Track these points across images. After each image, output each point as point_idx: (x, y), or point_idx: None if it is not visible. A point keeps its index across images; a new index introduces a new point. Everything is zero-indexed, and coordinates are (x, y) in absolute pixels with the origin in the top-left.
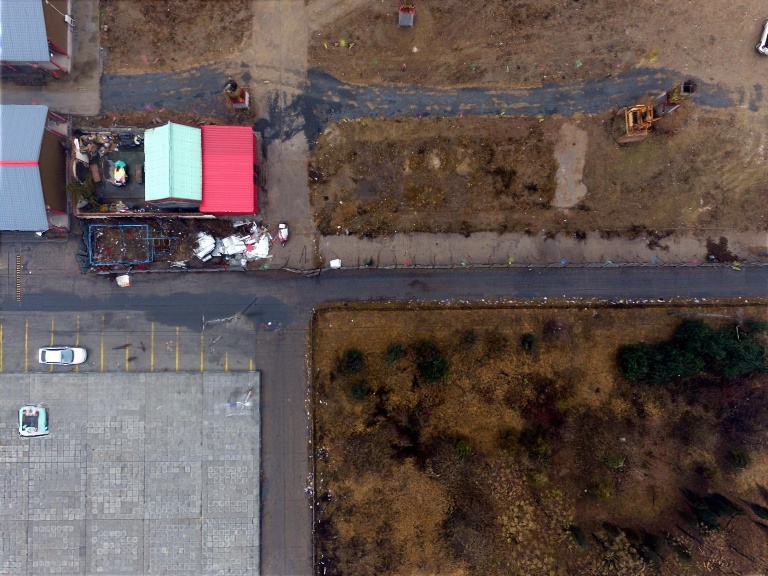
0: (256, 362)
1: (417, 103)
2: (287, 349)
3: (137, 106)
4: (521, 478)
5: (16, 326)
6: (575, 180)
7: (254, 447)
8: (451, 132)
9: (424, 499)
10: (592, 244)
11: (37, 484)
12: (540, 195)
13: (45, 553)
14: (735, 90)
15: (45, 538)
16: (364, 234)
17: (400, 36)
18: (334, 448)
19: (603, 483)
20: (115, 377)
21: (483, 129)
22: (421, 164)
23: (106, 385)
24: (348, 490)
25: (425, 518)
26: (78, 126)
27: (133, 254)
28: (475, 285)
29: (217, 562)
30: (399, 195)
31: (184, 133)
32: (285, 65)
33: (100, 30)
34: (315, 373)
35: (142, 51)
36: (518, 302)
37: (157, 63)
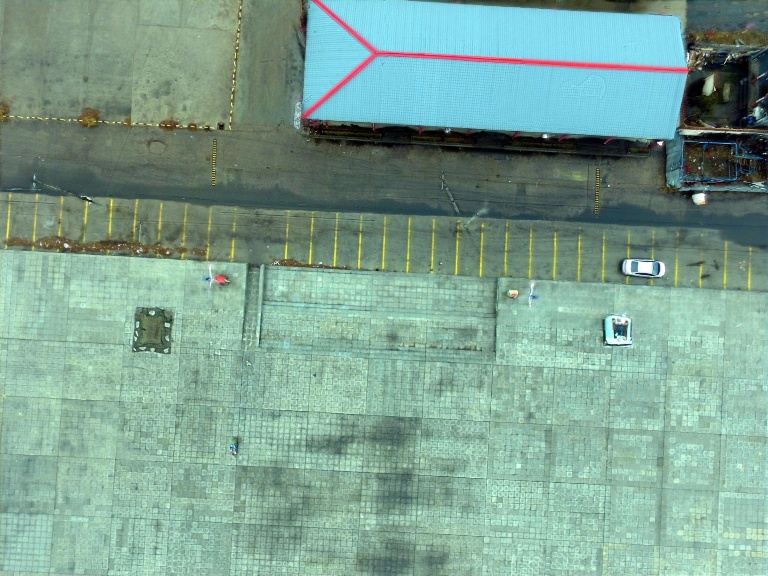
0: None
1: None
2: None
3: (721, 27)
4: None
5: (594, 238)
6: None
7: None
8: None
9: None
10: None
11: (618, 393)
12: None
13: (624, 461)
14: None
15: (624, 446)
16: None
17: None
18: None
19: None
20: (697, 292)
21: None
22: None
23: (688, 300)
24: None
25: None
26: None
27: (709, 173)
28: None
29: None
30: None
31: None
32: None
33: None
34: None
35: None
36: None
37: None
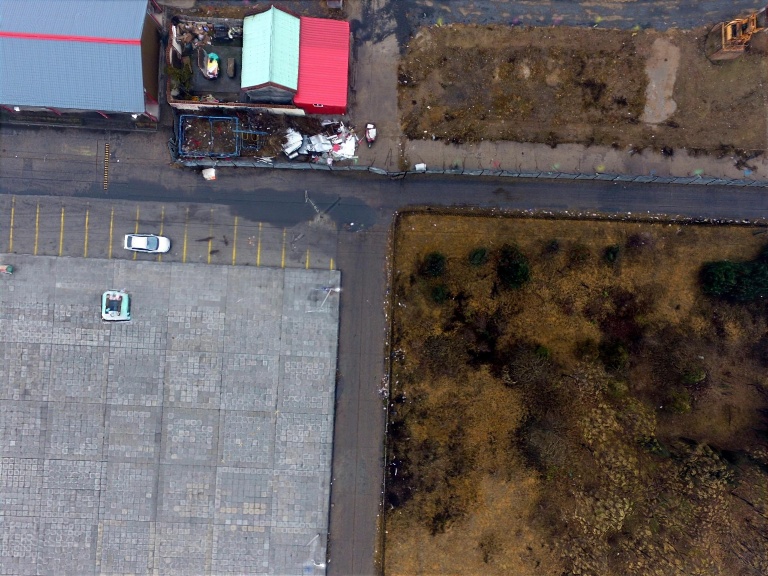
0: (337, 262)
1: (510, 11)
2: (368, 250)
3: (231, 1)
4: (607, 378)
5: (102, 213)
6: (665, 96)
7: (332, 345)
8: (542, 42)
9: (498, 406)
10: (679, 161)
11: (116, 369)
12: (629, 109)
13: (121, 437)
14: None
15: (122, 422)
16: (450, 140)
17: None
18: (411, 351)
19: (682, 397)
20: (198, 267)
21: (575, 40)
22: (511, 73)
23: (189, 275)
24: (423, 393)
25: (499, 425)
26: None
27: (220, 148)
28: (559, 196)
29: (290, 456)
30: (487, 103)
31: (285, 20)
32: None
33: None
34: (395, 275)
35: None
36: (602, 215)
37: None
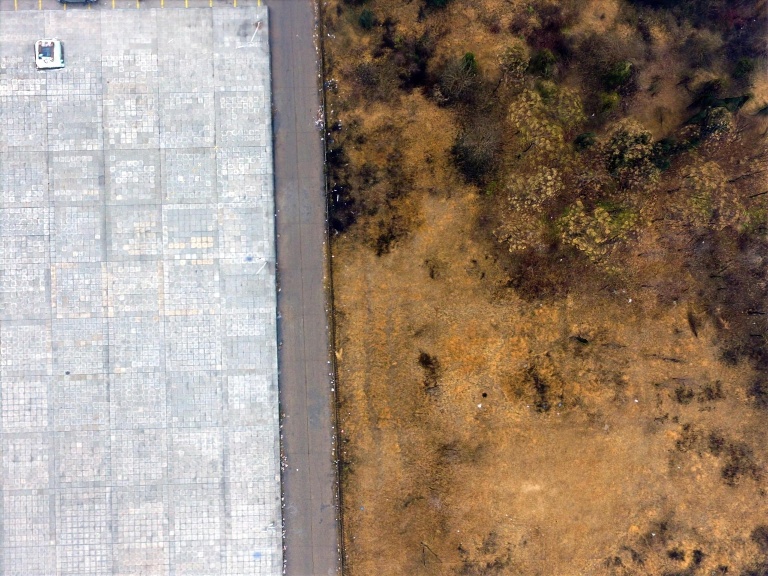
0: None
1: None
2: None
3: None
4: None
5: None
6: None
7: (265, 78)
8: None
9: (433, 126)
10: None
11: (55, 116)
12: None
13: (66, 182)
14: None
15: (65, 168)
16: None
17: None
18: (343, 79)
19: None
20: (127, 12)
21: None
22: None
23: (118, 19)
24: (358, 118)
25: (435, 143)
26: None
27: None
28: None
29: (232, 189)
30: None
31: None
32: None
33: None
34: (322, 6)
35: None
36: None
37: None
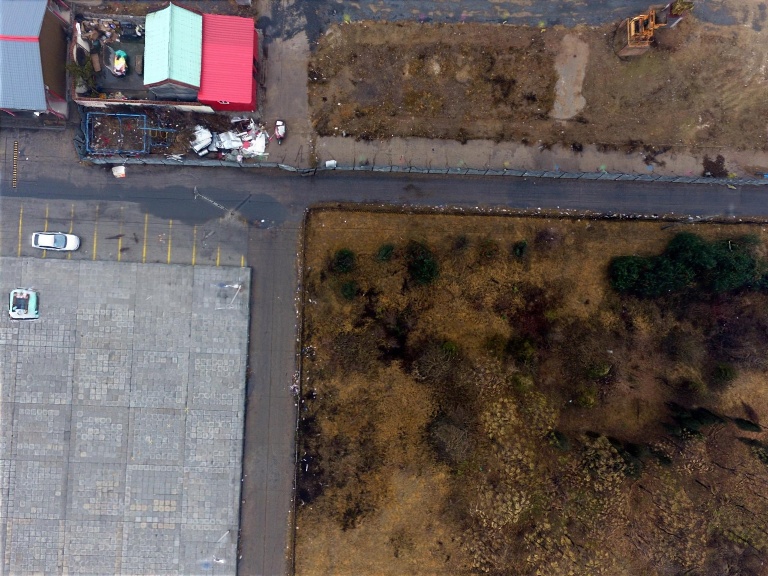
0: (248, 259)
1: (420, 8)
2: (279, 247)
3: None
4: (506, 373)
5: (11, 211)
6: (574, 92)
7: (242, 341)
8: (452, 39)
9: (409, 401)
10: (588, 157)
11: (25, 367)
12: (538, 105)
13: (30, 435)
14: (739, 9)
15: (30, 421)
16: (361, 136)
17: None
18: (321, 347)
19: (588, 391)
20: (107, 265)
21: (484, 37)
22: (421, 69)
23: (97, 273)
24: (333, 389)
25: (409, 420)
26: None
27: (130, 145)
28: (469, 192)
29: (200, 453)
30: (397, 99)
31: (185, 17)
32: None
33: None
34: (306, 271)
35: None
36: (512, 211)
37: None
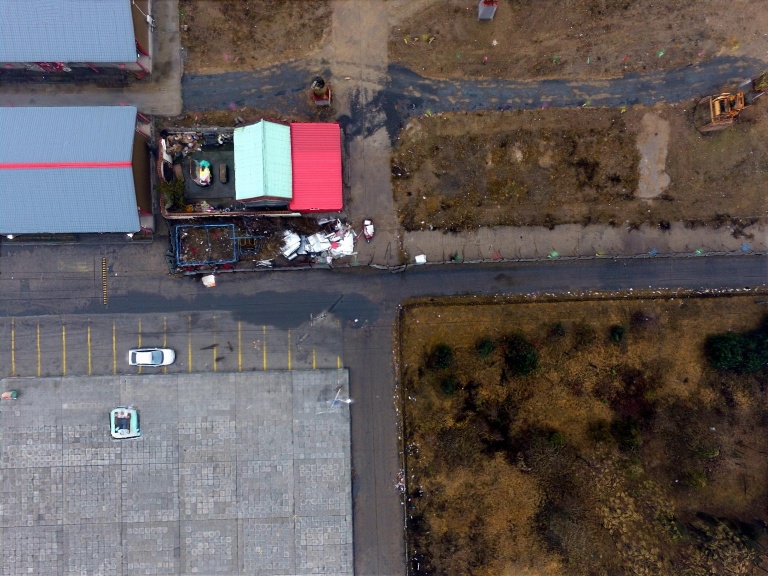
0: (343, 359)
1: (498, 96)
2: (374, 346)
3: (219, 105)
4: (623, 469)
5: (103, 328)
6: (658, 170)
7: (345, 444)
8: (533, 125)
9: (516, 493)
10: (676, 234)
11: (130, 486)
12: (623, 186)
13: (140, 555)
14: None
15: (139, 540)
16: (448, 229)
17: (480, 29)
18: (424, 444)
19: (697, 473)
20: (205, 377)
21: (565, 121)
22: (503, 157)
23: (196, 386)
24: (440, 485)
25: (517, 512)
26: (160, 127)
27: (218, 254)
28: (560, 278)
29: (311, 560)
30: (482, 189)
31: (275, 131)
32: (365, 61)
33: (180, 30)
34: (403, 369)
35: (222, 50)
36: (604, 294)
37: (237, 62)
